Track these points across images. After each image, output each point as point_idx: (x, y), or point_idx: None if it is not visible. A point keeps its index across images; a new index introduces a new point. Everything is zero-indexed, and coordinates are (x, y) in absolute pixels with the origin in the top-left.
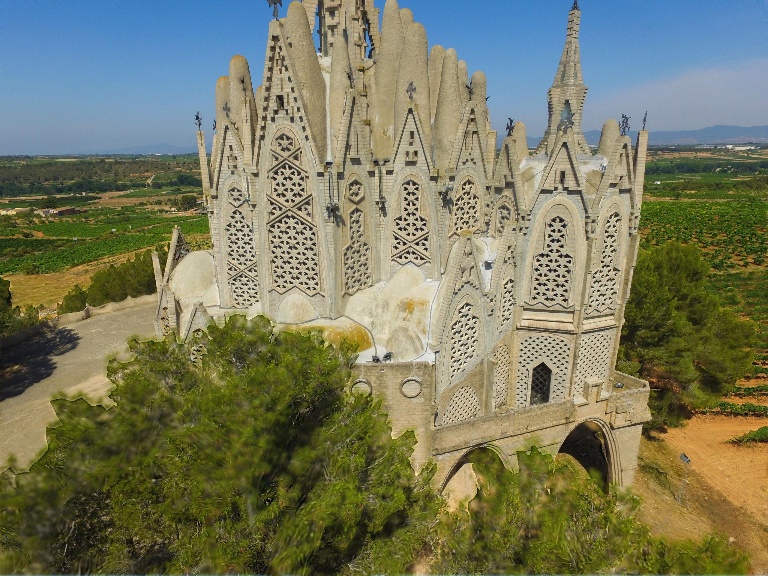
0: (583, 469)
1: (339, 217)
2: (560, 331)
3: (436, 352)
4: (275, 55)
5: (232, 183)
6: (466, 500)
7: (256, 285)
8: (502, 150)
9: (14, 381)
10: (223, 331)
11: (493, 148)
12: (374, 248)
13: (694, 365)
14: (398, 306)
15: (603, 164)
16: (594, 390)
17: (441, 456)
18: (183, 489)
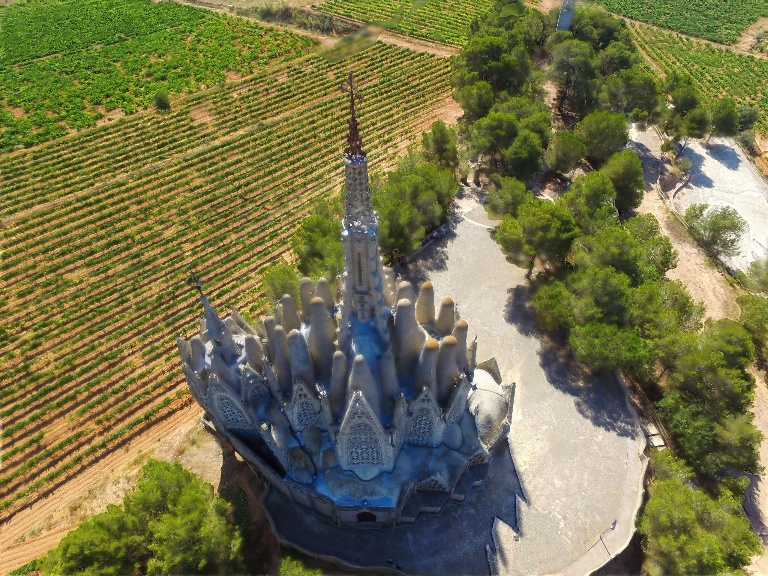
0: None
1: None
2: None
3: None
4: None
5: None
6: None
7: None
8: None
9: (558, 372)
10: None
11: None
12: None
13: None
14: None
15: None
16: None
17: None
18: None
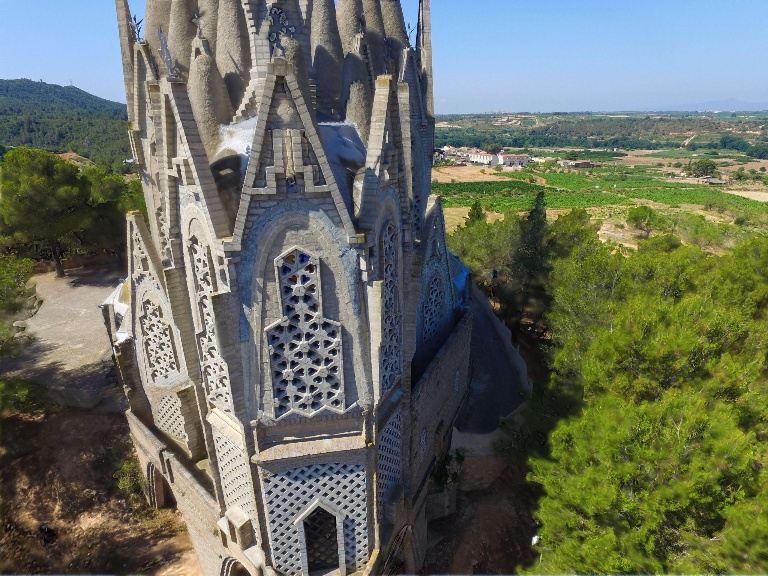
0: None
1: (148, 176)
2: None
3: None
4: None
5: None
6: None
7: None
8: None
9: None
10: None
11: None
12: None
13: None
14: None
15: None
16: None
17: None
18: None
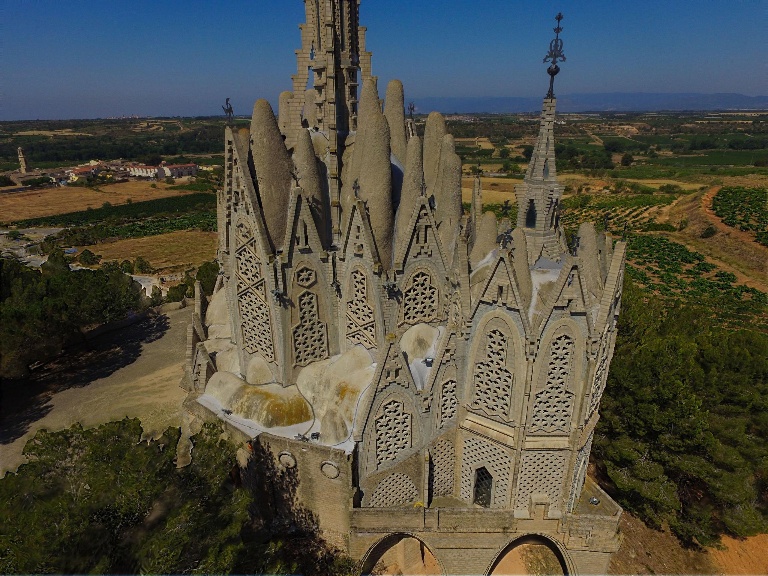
0: (560, 568)
1: (287, 301)
2: (500, 442)
3: (359, 441)
4: (233, 156)
5: None
6: (405, 570)
7: None
8: None
9: (110, 363)
10: (95, 437)
11: (463, 235)
12: (331, 325)
13: (758, 479)
14: (336, 388)
15: None
16: (541, 507)
17: (360, 534)
18: (13, 571)
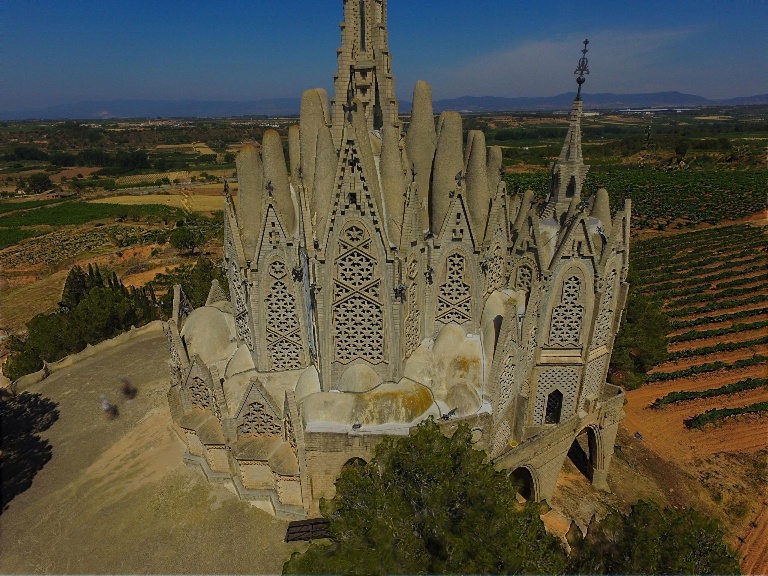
0: (567, 457)
1: (403, 295)
2: (571, 364)
3: (489, 401)
4: (348, 156)
5: (274, 257)
6: None
7: (297, 348)
8: (525, 220)
9: (10, 472)
10: None
11: None
12: (421, 312)
13: None
14: (453, 364)
15: (598, 226)
16: (592, 404)
17: None
18: None
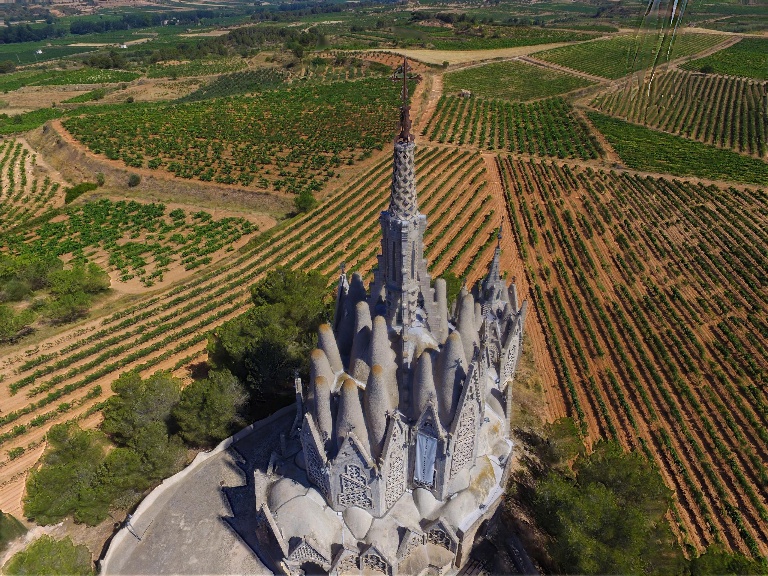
0: None
1: None
2: None
3: None
4: None
5: None
6: None
7: None
8: None
9: None
10: None
11: None
12: None
13: None
14: (490, 433)
15: None
16: None
17: None
18: None
